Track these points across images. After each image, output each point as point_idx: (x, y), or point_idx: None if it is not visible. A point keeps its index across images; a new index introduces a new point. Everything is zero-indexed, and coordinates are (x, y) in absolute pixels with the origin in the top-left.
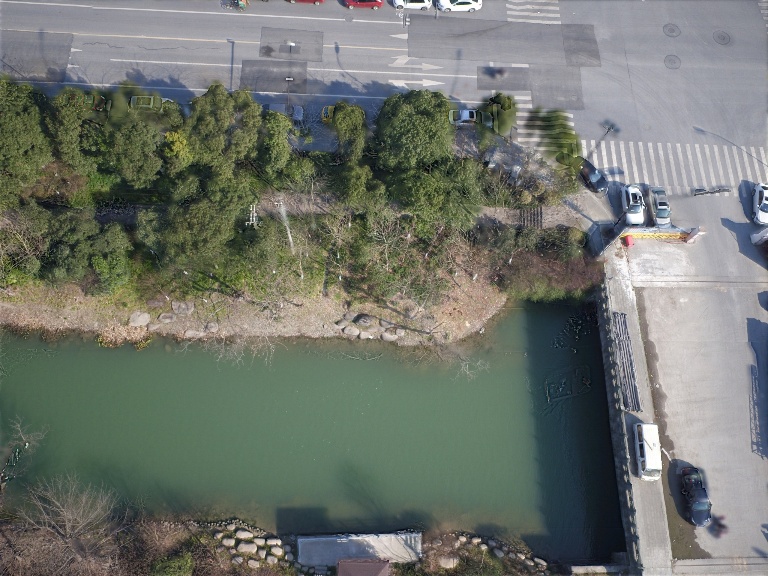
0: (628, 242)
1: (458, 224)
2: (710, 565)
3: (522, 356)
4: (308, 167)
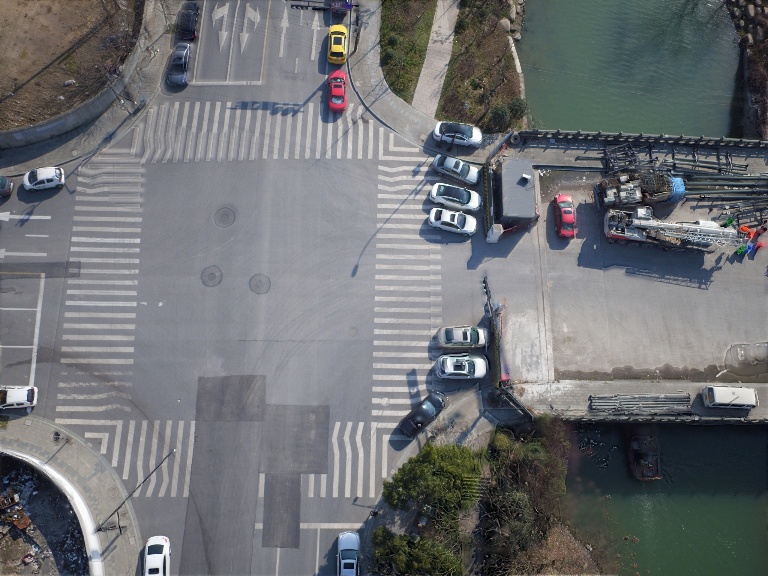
0: (506, 380)
1: None
2: None
3: (610, 501)
4: None
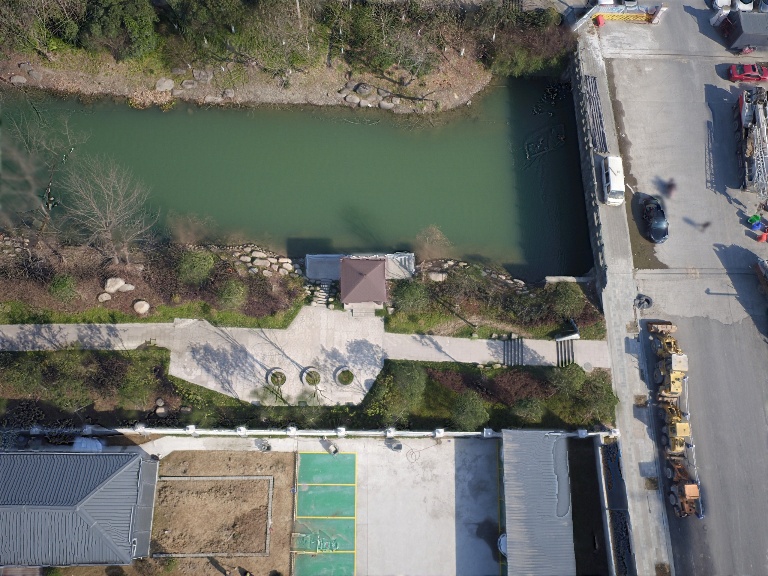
0: (599, 21)
1: (447, 7)
2: (667, 274)
3: (505, 125)
4: None
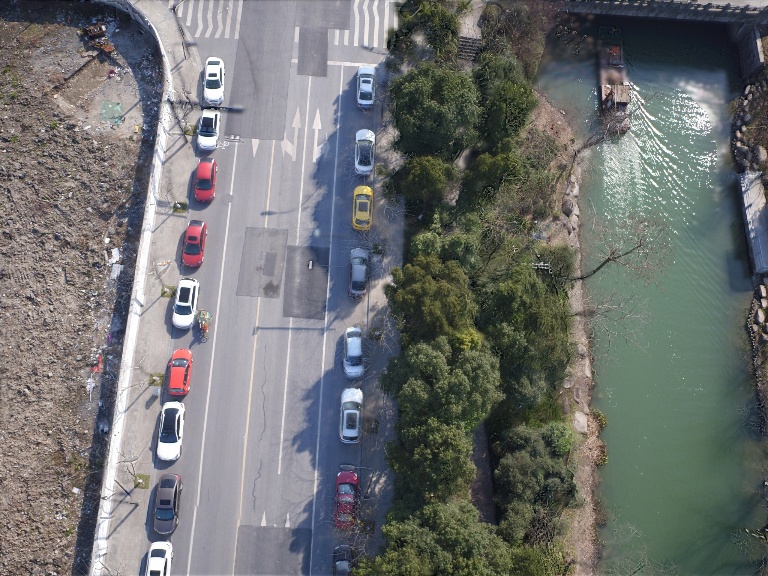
0: None
1: None
2: None
3: (581, 84)
4: None
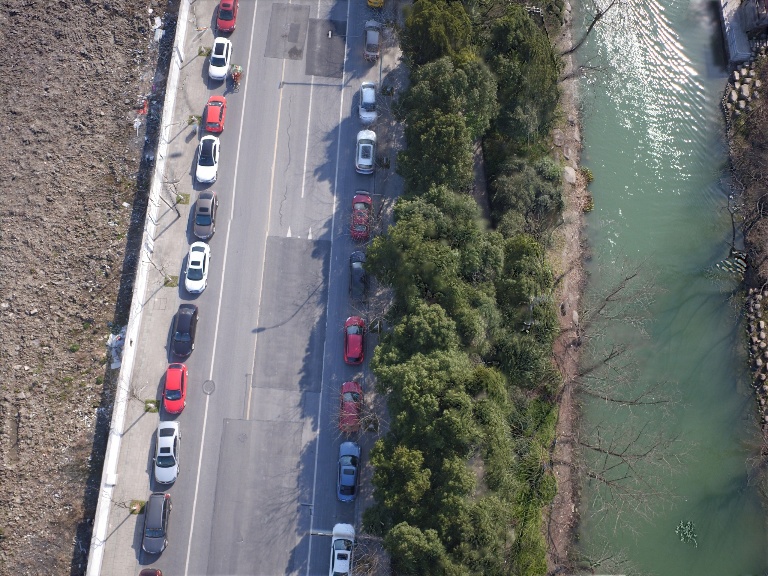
0: None
1: None
2: None
3: None
4: None
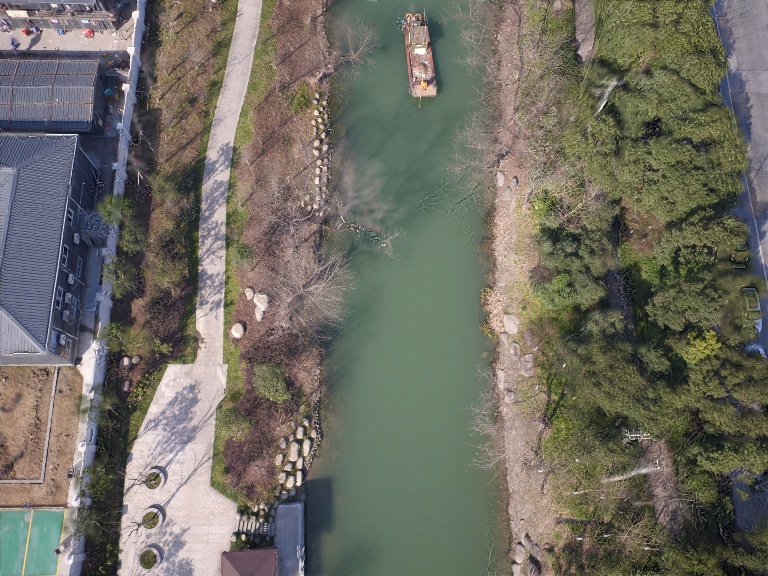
0: None
1: None
2: None
3: None
4: (710, 498)
